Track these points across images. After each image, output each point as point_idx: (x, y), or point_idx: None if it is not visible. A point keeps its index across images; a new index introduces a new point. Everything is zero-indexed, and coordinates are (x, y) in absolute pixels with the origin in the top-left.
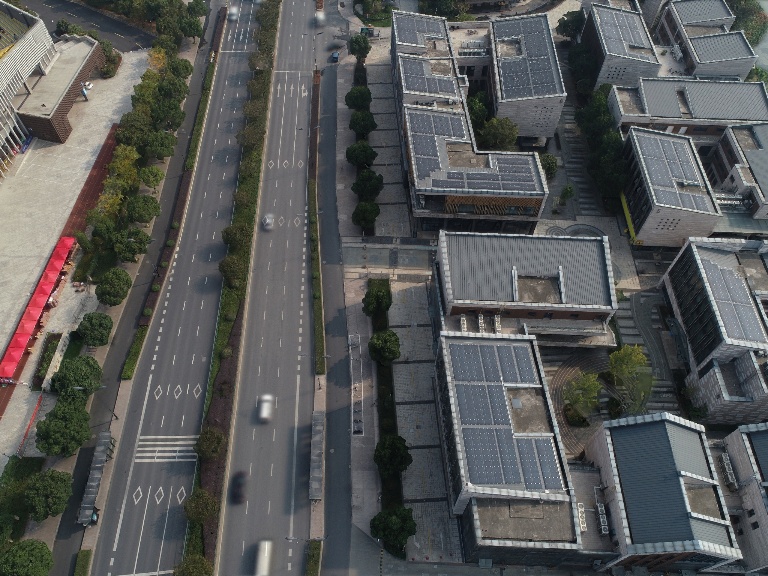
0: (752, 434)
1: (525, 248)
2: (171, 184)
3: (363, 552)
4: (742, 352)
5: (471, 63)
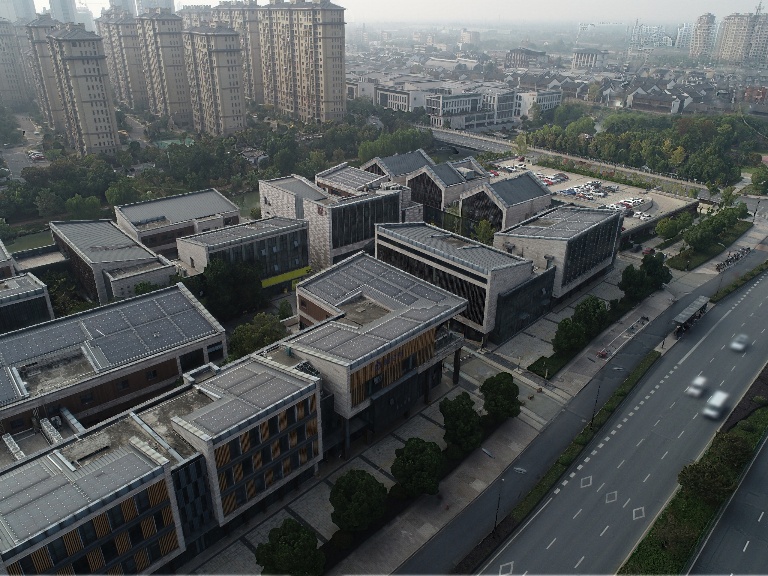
0: None
1: (436, 247)
2: None
3: None
4: None
5: None
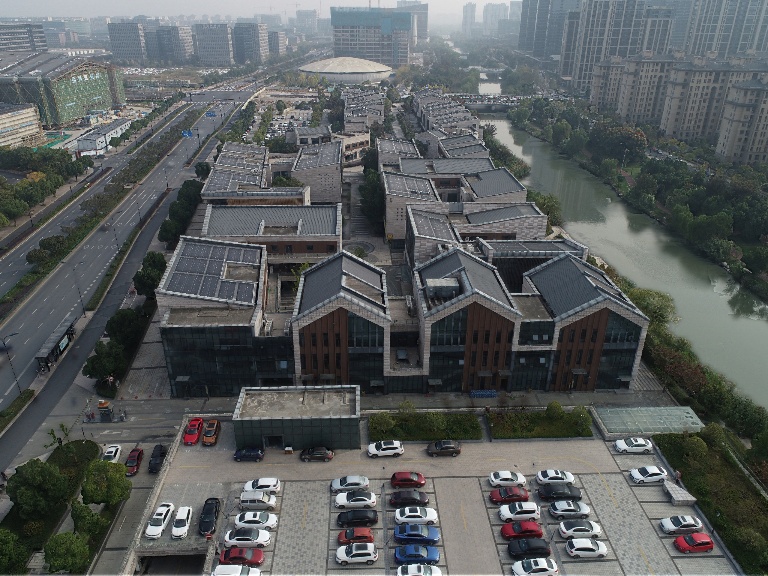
0: (422, 270)
1: (275, 212)
2: (15, 235)
3: (74, 397)
4: (434, 248)
5: (284, 169)
